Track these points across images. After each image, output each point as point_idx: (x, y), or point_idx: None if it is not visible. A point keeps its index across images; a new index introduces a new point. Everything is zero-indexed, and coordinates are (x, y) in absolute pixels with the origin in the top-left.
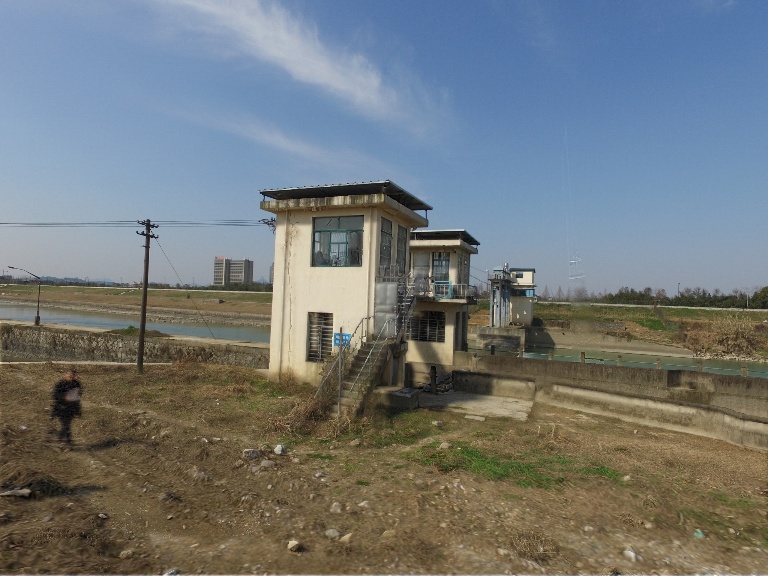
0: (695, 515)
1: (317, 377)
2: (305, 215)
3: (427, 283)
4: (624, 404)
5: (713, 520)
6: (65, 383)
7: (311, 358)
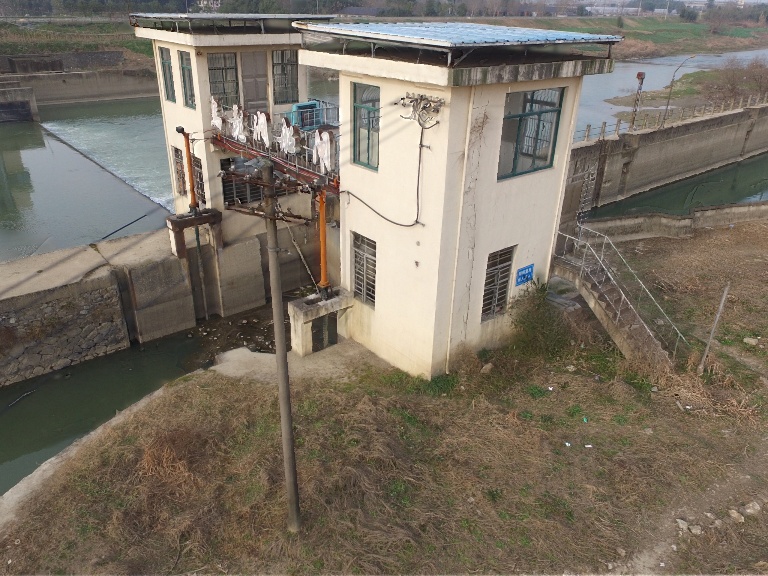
0: None
1: (494, 336)
2: (498, 91)
3: (266, 105)
4: (602, 228)
5: None
6: None
7: (481, 316)
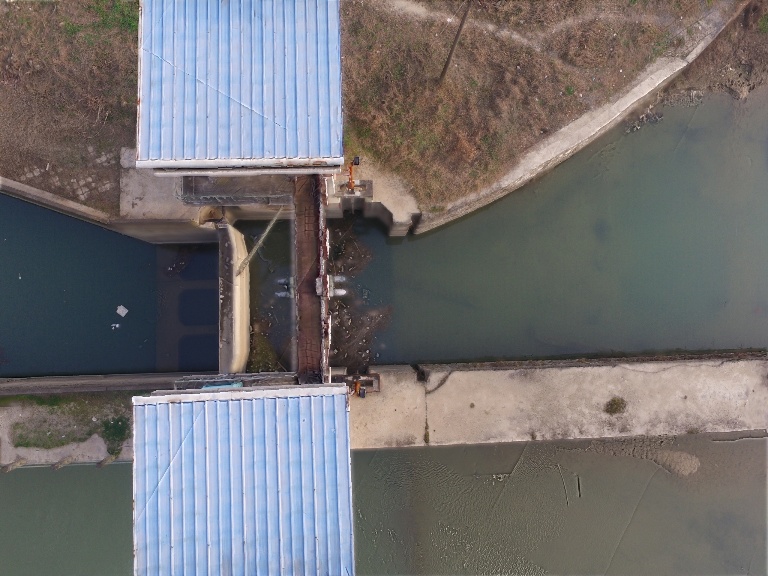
0: (43, 2)
1: None
2: None
3: None
4: None
5: (37, 2)
6: (455, 33)
7: None
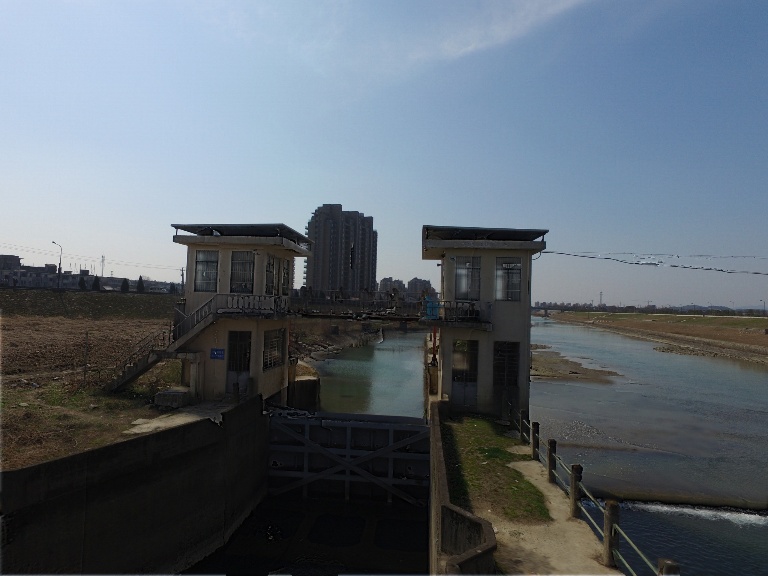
0: None
1: None
2: None
3: None
4: None
5: None
6: None
7: None
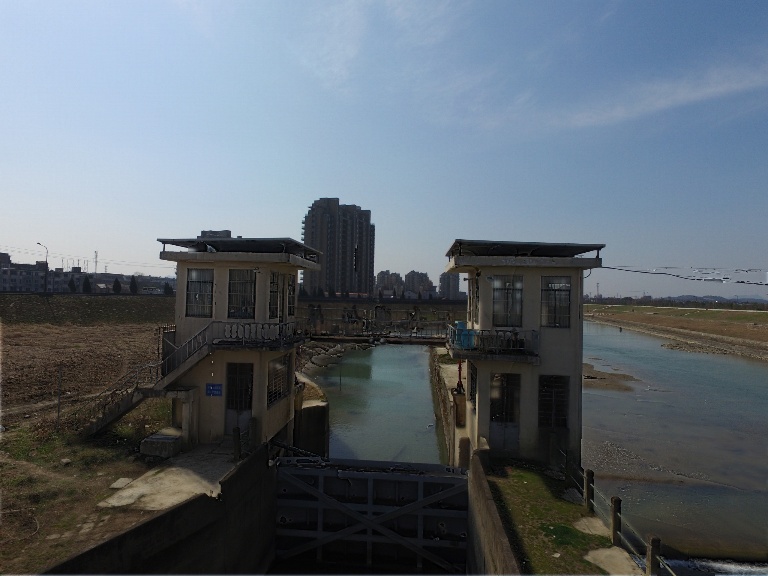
0: None
1: None
2: None
3: None
4: None
5: None
6: None
7: None
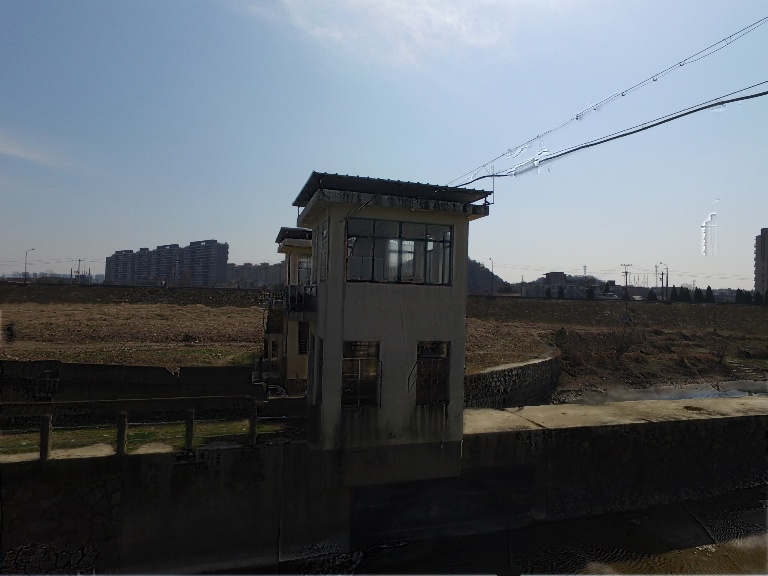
0: None
1: None
2: None
3: None
4: None
5: None
6: None
7: None
